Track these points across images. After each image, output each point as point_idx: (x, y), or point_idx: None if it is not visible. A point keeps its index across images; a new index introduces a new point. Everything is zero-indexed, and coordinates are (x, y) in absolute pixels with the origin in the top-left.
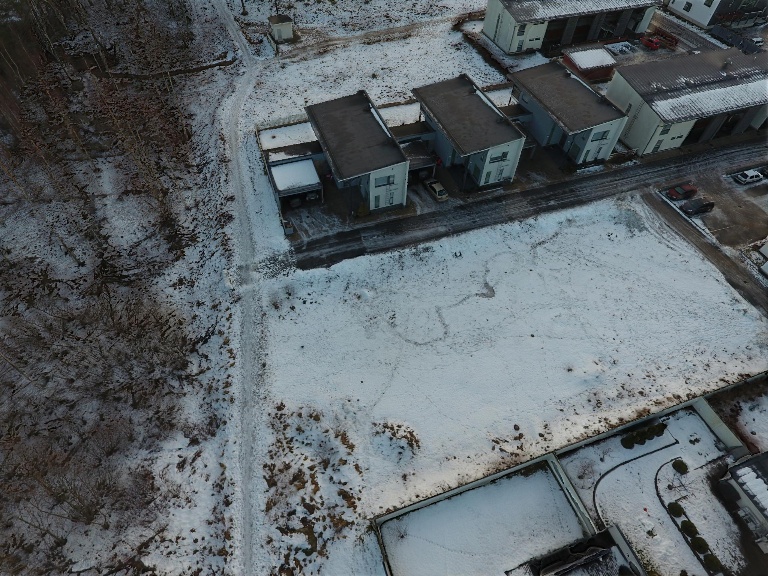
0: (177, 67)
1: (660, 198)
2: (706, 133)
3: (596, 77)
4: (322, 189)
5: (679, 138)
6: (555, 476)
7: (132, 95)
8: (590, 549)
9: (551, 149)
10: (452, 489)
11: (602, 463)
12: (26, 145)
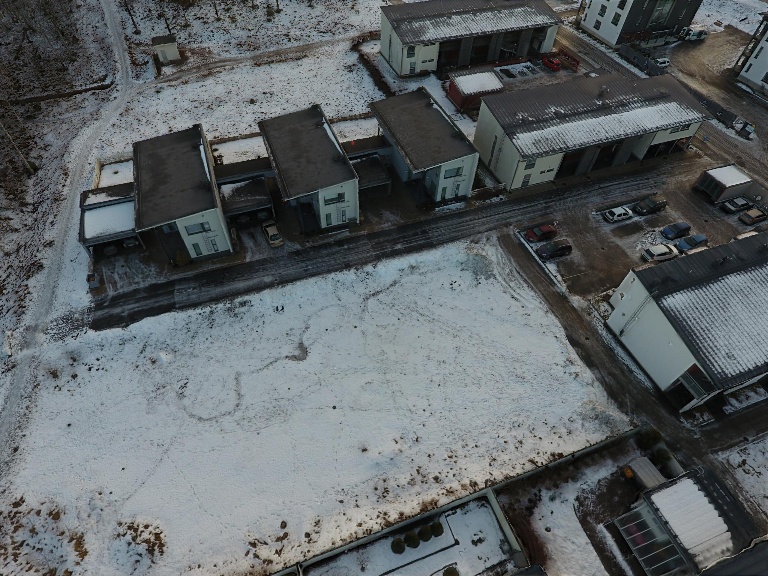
0: (48, 91)
1: (518, 240)
2: (581, 165)
3: None
4: (138, 235)
5: (550, 172)
6: None
7: None
8: None
9: (413, 184)
10: None
11: (361, 573)
12: None
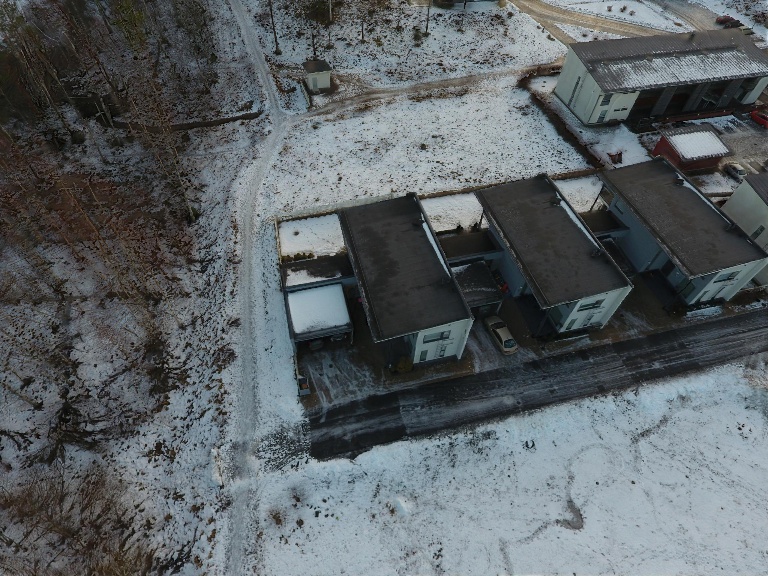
0: (194, 118)
1: None
2: None
3: (700, 166)
4: (352, 331)
5: None
6: None
7: (138, 153)
8: None
9: (651, 277)
10: None
11: None
12: (5, 217)
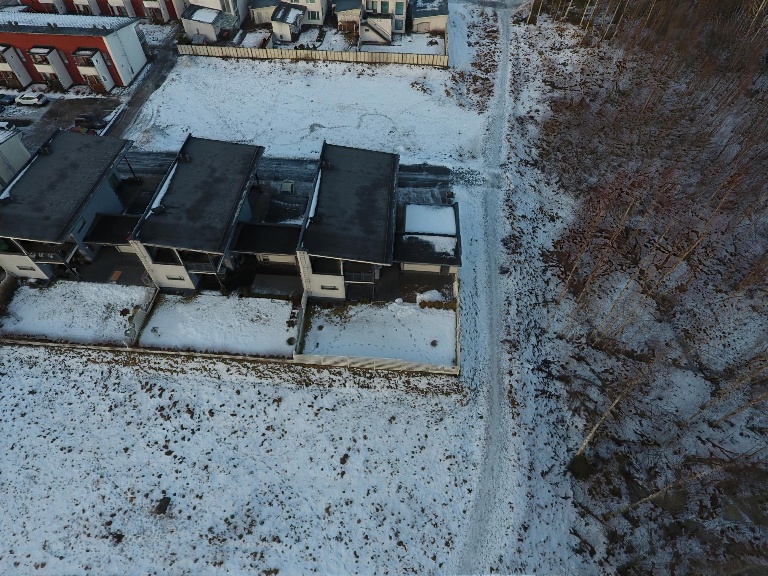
0: None
1: None
2: None
3: None
4: None
5: None
6: None
7: None
8: (372, 22)
9: None
10: (410, 53)
11: None
12: None
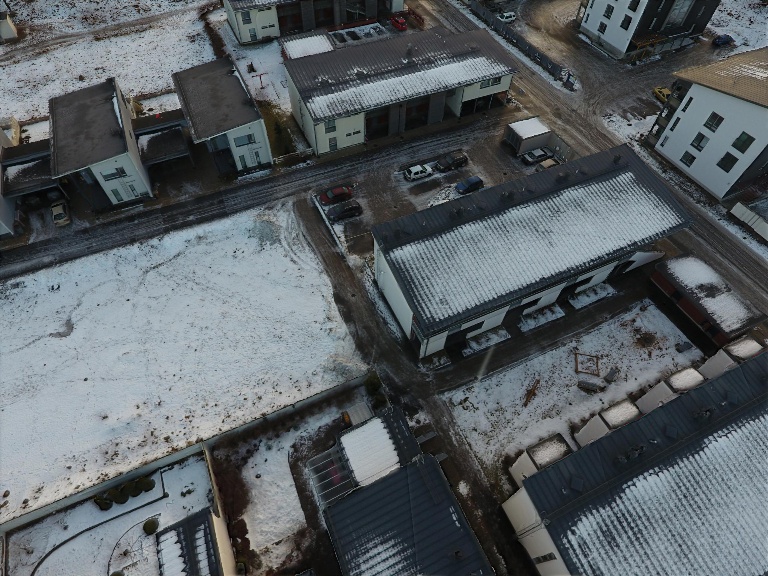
0: None
1: (312, 204)
2: (391, 126)
3: None
4: None
5: (357, 134)
6: (3, 553)
7: None
8: None
9: (220, 155)
10: None
11: (63, 531)
12: None
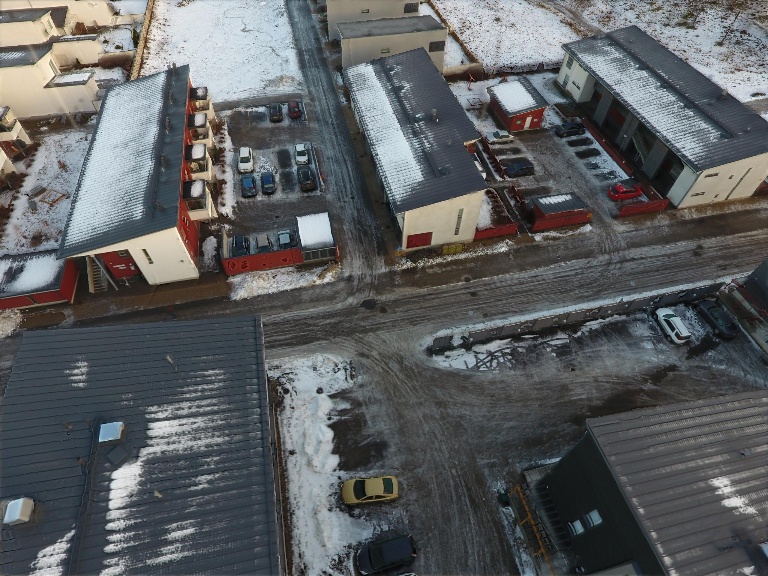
0: None
1: None
2: None
3: None
4: None
5: None
6: None
7: None
8: None
9: None
10: None
11: None
12: None
